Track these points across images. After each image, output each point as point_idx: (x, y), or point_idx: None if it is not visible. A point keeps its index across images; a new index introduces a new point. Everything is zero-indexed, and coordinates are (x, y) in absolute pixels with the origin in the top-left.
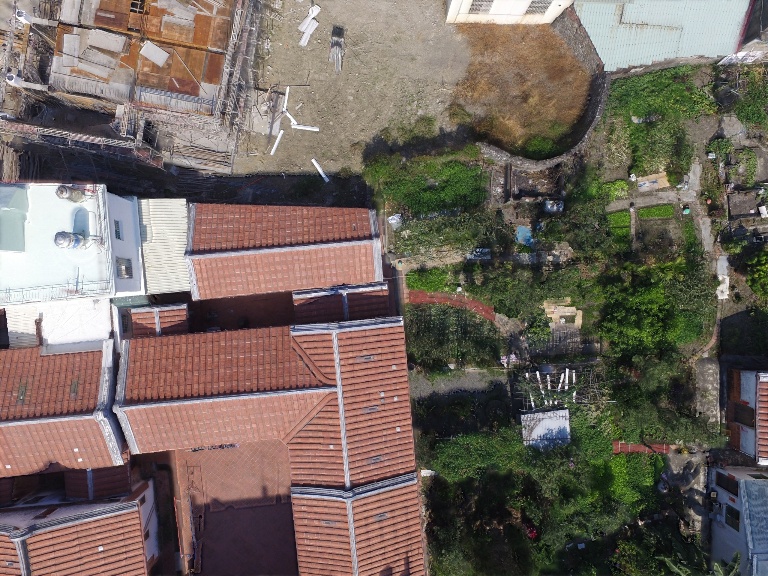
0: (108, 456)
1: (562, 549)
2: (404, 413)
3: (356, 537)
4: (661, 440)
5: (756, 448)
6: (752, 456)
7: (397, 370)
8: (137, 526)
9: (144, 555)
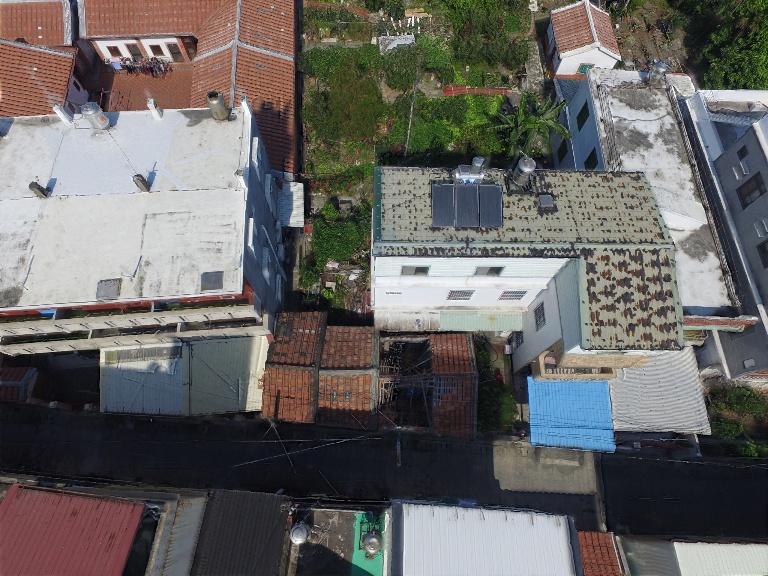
0: (62, 36)
1: (423, 155)
2: (288, 24)
3: (237, 68)
4: (500, 87)
5: (557, 50)
6: (558, 61)
7: (286, 1)
8: (68, 68)
9: (67, 88)
